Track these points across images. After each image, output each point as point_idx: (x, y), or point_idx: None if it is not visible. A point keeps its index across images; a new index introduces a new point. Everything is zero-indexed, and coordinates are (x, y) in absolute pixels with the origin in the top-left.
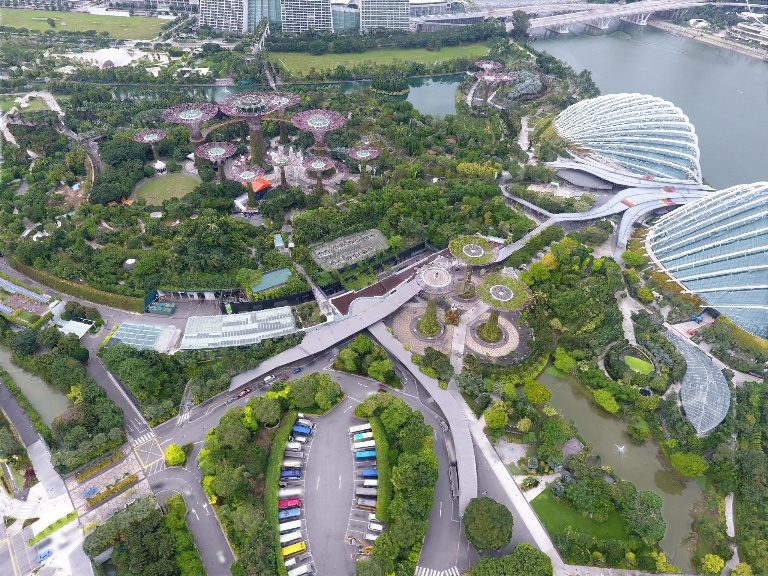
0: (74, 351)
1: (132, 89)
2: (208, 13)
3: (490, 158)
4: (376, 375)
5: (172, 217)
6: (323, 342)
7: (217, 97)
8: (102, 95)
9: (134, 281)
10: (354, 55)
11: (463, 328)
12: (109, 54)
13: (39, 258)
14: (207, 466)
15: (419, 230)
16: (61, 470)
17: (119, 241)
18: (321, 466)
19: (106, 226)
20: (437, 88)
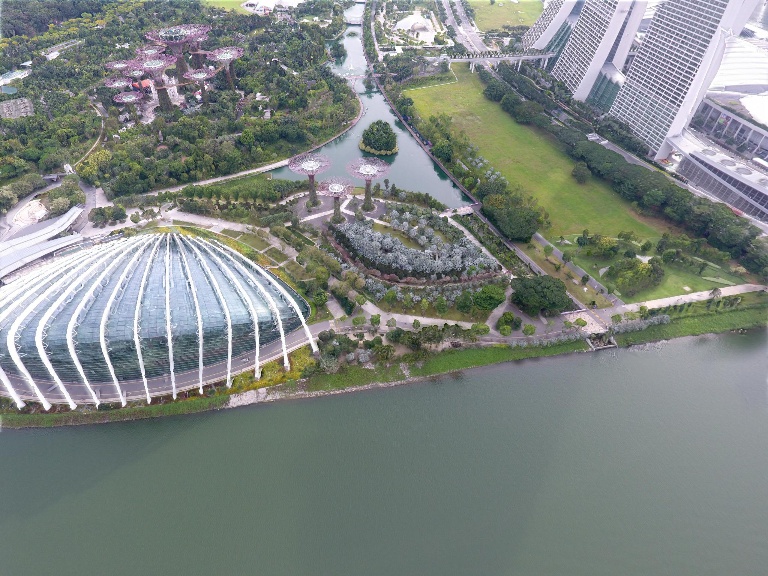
0: None
1: None
2: None
3: None
4: None
5: None
6: None
7: None
8: None
9: None
10: (504, 119)
11: None
12: None
13: None
14: None
15: (8, 126)
16: None
17: None
18: None
19: None
20: (450, 196)
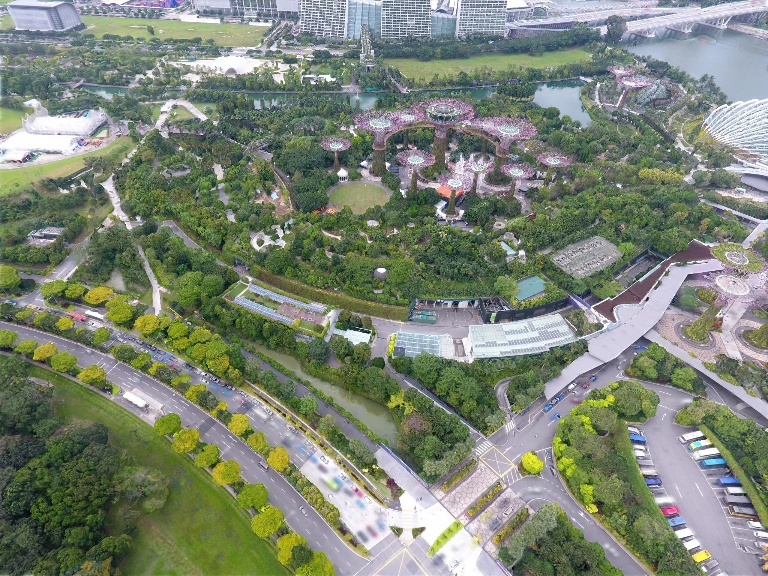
0: (374, 360)
1: (260, 96)
2: (308, 20)
3: (663, 164)
4: (682, 383)
5: (389, 225)
6: (611, 350)
7: (350, 104)
8: (249, 103)
9: (393, 290)
10: (461, 61)
11: (728, 335)
12: (230, 62)
13: (290, 267)
14: (582, 475)
15: (646, 237)
16: (433, 479)
17: (354, 250)
18: (672, 474)
19: (328, 235)
20: None
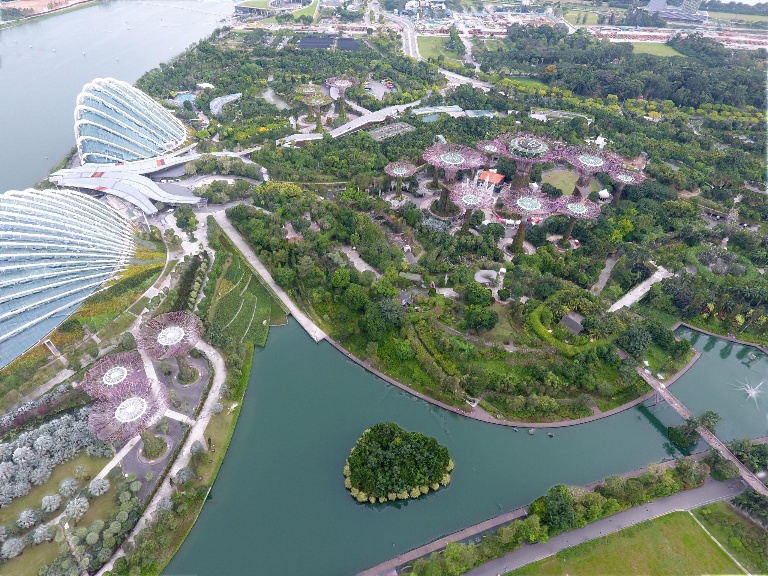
0: (502, 104)
1: None
2: None
3: None
4: None
5: None
6: None
7: None
8: None
9: None
10: None
11: (325, 121)
12: None
13: None
14: None
15: None
16: None
17: None
18: None
19: None
20: None
